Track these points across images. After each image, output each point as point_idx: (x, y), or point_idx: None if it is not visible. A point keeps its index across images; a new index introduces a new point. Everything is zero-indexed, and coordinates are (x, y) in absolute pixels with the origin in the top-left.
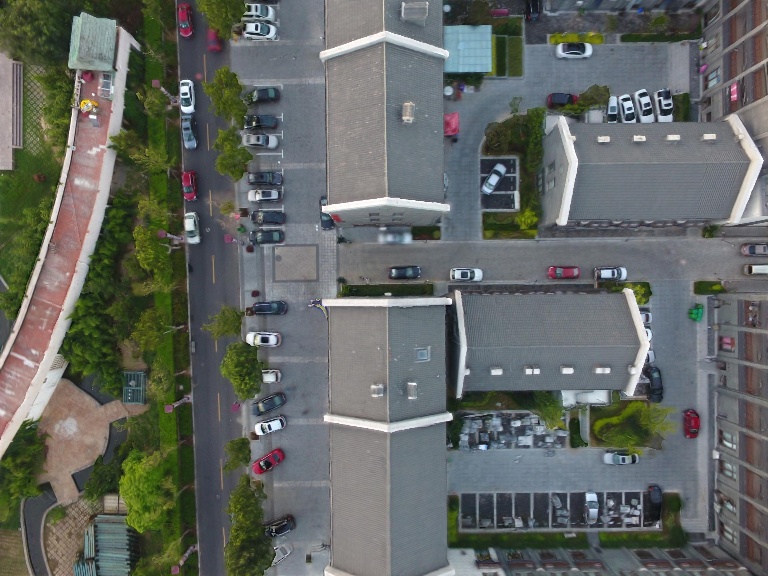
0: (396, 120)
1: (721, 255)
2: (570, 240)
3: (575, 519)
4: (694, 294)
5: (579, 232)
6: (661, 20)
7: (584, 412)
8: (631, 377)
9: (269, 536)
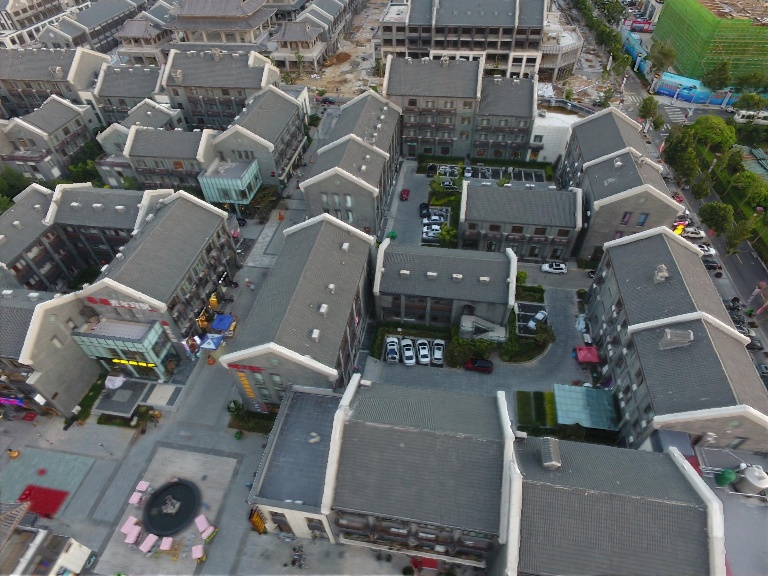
0: None
1: None
2: None
3: (476, 170)
4: None
5: None
6: None
7: None
8: None
9: None
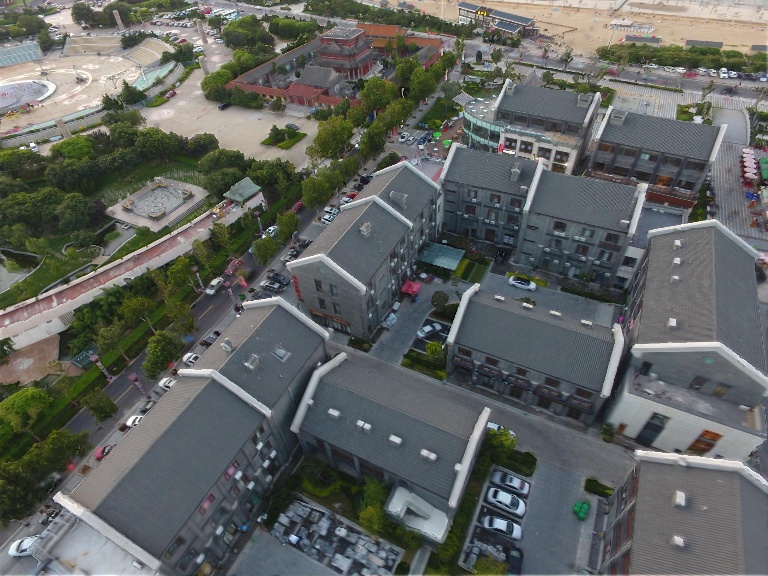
0: (357, 231)
1: (622, 466)
2: (473, 394)
3: None
4: (584, 491)
5: (483, 391)
6: (583, 275)
7: (420, 563)
8: (456, 477)
9: (45, 521)
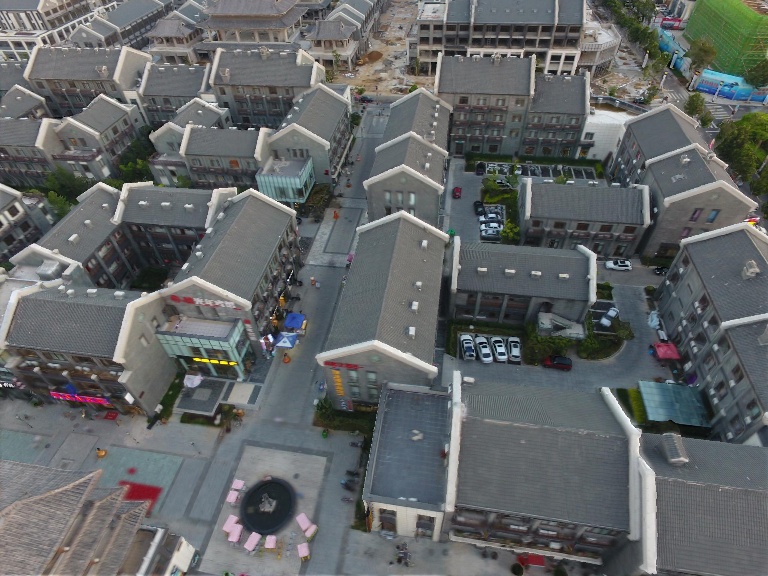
0: None
1: None
2: None
3: (525, 168)
4: None
5: None
6: None
7: None
8: None
9: None
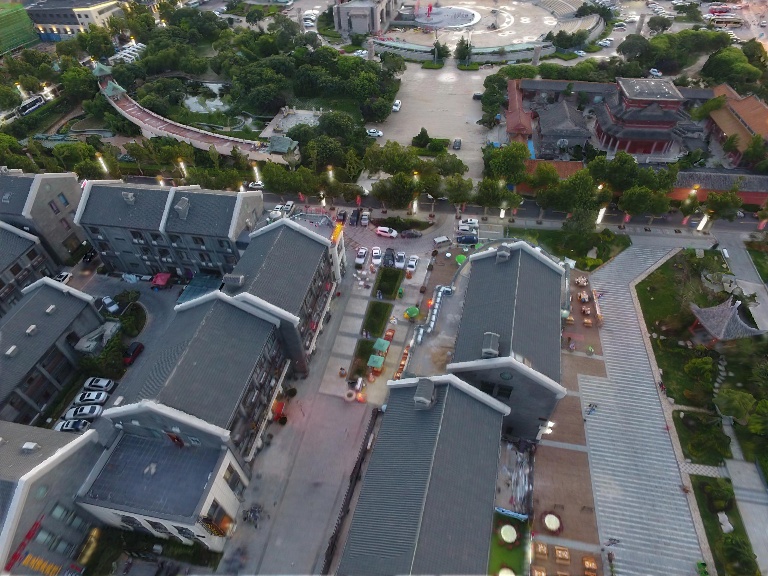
0: None
1: None
2: None
3: None
4: None
5: None
6: None
7: None
8: None
9: None
